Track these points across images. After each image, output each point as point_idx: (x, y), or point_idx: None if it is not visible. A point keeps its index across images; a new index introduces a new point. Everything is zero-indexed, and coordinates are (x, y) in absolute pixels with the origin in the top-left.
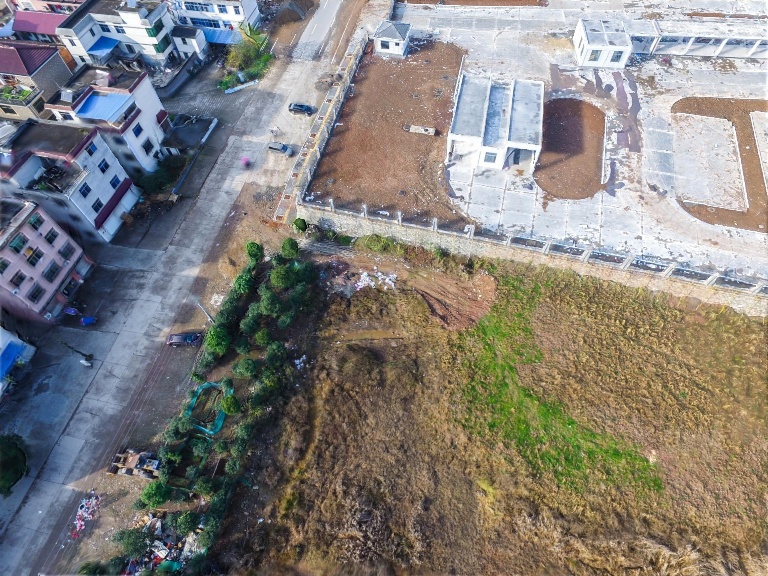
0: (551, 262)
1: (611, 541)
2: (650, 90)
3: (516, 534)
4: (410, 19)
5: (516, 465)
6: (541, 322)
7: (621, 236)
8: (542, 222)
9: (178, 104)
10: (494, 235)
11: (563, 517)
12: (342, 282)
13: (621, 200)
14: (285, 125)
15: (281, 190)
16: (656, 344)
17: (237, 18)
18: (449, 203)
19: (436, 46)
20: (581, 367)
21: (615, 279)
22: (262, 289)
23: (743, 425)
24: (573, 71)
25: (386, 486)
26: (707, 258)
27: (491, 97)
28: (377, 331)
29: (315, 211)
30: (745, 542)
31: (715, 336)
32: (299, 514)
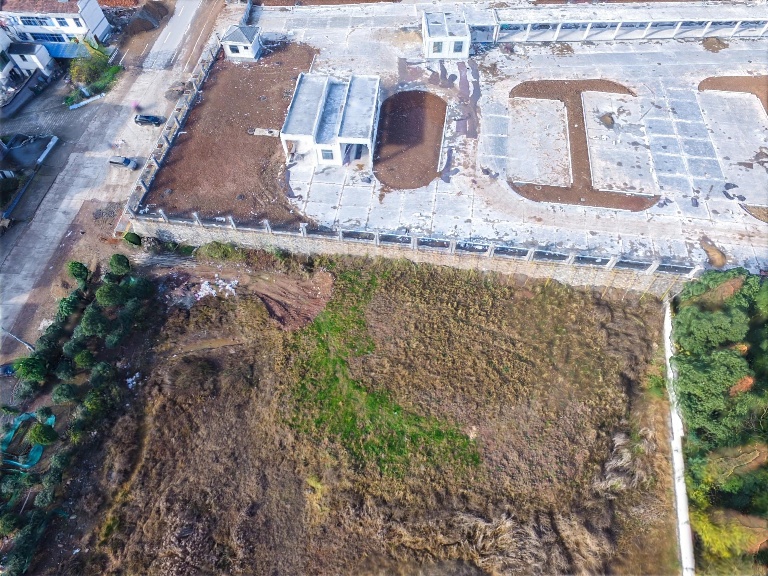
0: (385, 253)
1: (430, 521)
2: (491, 77)
3: (341, 527)
4: (266, 22)
5: (340, 458)
6: (375, 313)
7: (452, 221)
8: (377, 214)
9: (19, 124)
10: (329, 231)
11: (386, 504)
12: (181, 293)
13: (455, 186)
14: (131, 138)
15: (123, 205)
16: (484, 322)
17: (80, 31)
18: (287, 203)
19: (289, 47)
20: (411, 353)
21: (447, 263)
22: (89, 309)
23: (560, 391)
24: (420, 64)
25: (212, 497)
26: (531, 235)
27: (330, 94)
28: (216, 340)
29: (149, 223)
30: (556, 503)
31: (540, 309)
32: (118, 538)
